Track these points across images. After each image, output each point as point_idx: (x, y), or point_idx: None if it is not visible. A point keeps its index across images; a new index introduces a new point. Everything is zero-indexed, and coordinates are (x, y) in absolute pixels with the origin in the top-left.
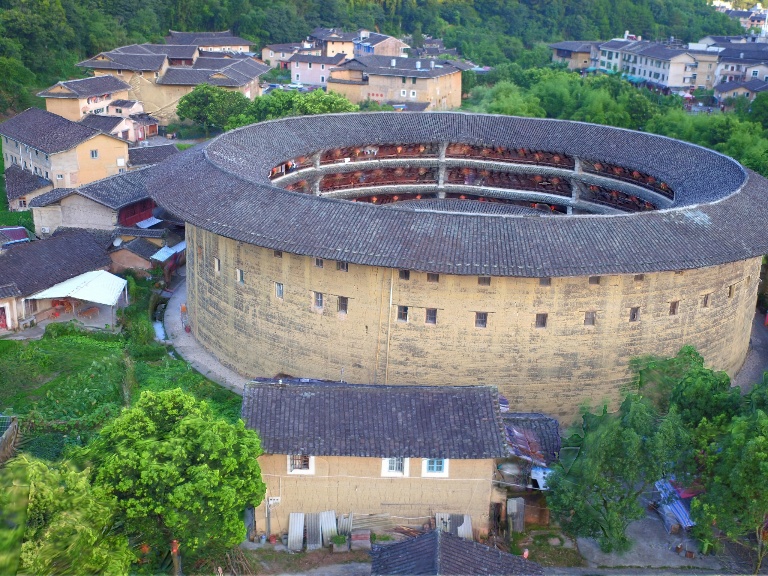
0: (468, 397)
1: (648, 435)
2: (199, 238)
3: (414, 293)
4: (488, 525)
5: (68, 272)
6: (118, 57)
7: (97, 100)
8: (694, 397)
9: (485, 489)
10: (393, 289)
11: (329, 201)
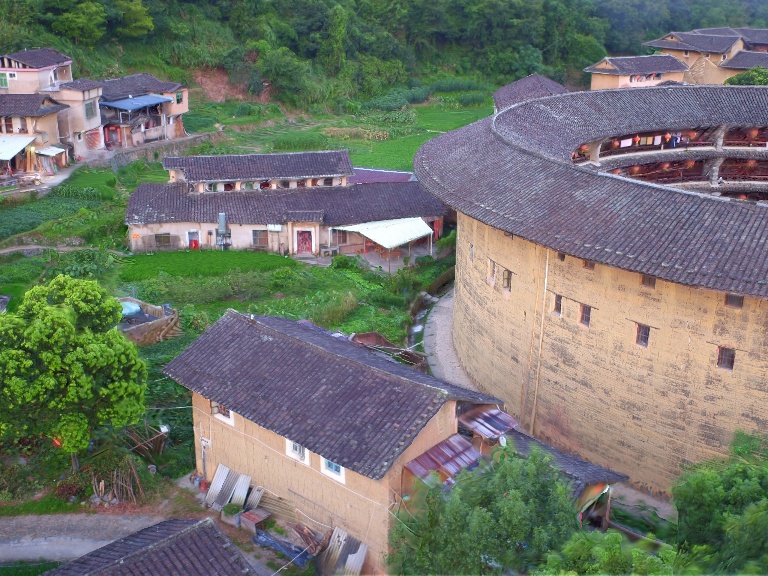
0: (408, 394)
1: (472, 507)
2: None
3: (568, 280)
4: (387, 569)
5: (392, 214)
6: (688, 37)
7: (642, 79)
8: (686, 502)
9: (382, 518)
10: (549, 270)
11: (526, 153)
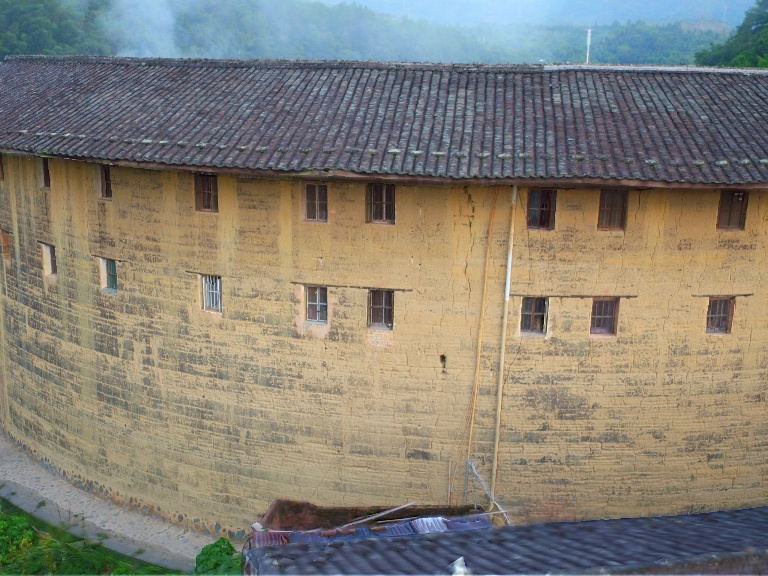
0: None
1: None
2: (2, 211)
3: (565, 262)
4: None
5: None
6: None
7: None
8: None
9: None
10: (512, 256)
11: (325, 67)
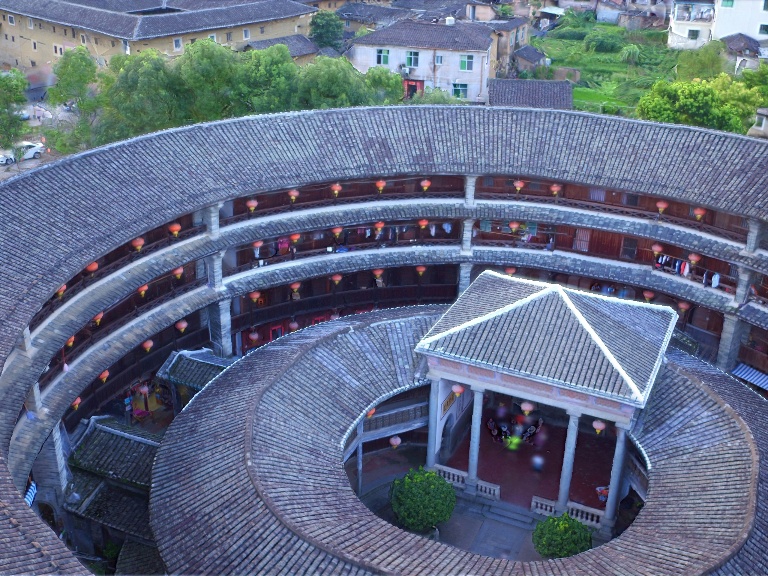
0: None
1: None
2: None
3: None
4: None
5: None
6: None
7: None
8: None
9: None
10: None
11: None
